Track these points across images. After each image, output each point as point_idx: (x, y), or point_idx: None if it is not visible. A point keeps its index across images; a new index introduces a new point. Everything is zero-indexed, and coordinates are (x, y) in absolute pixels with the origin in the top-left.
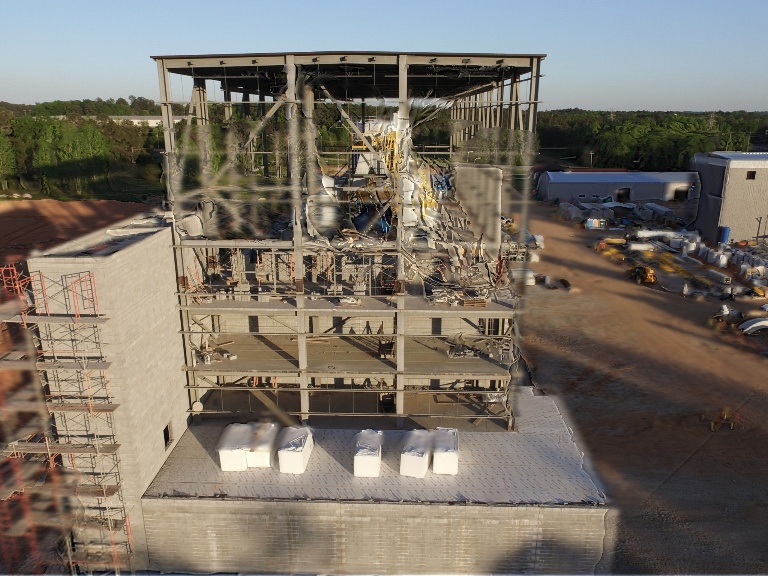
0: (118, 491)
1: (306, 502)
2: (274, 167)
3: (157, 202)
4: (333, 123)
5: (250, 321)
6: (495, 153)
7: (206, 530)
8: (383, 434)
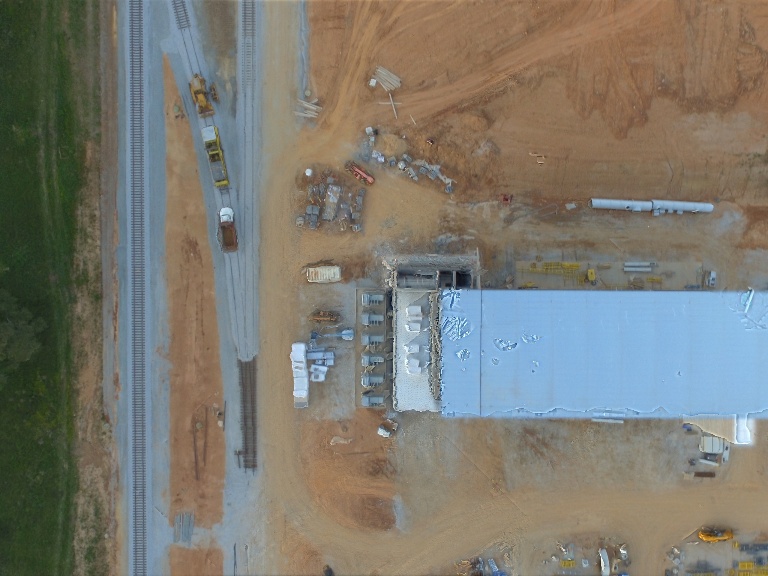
0: None
1: (395, 333)
2: None
3: None
4: None
5: None
6: None
7: None
8: (427, 352)
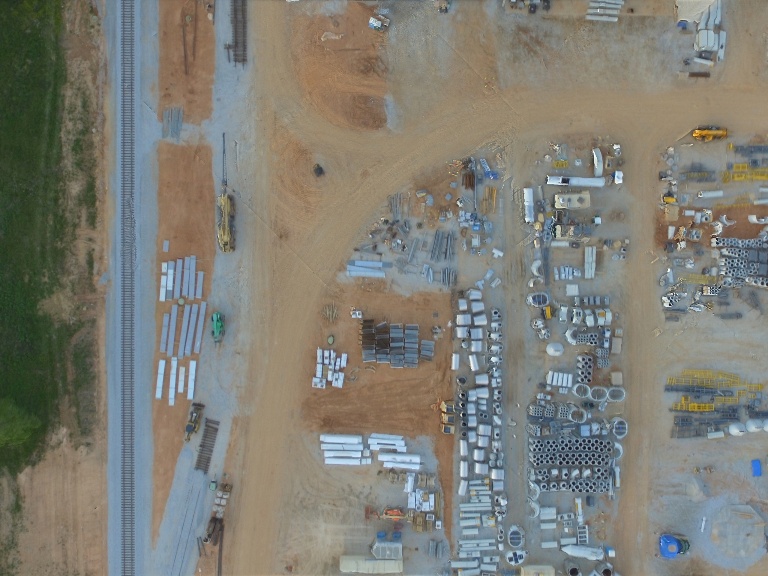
0: None
1: None
2: None
3: None
4: None
5: None
6: None
7: None
8: None
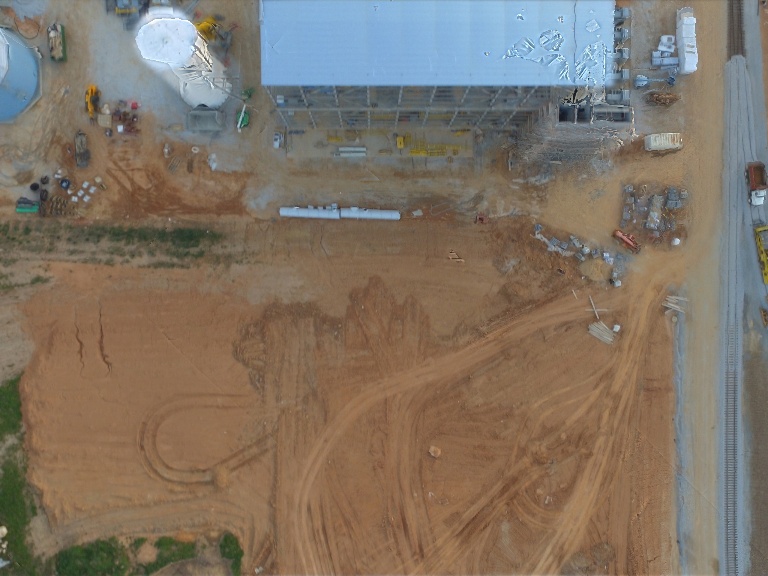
0: None
1: None
2: None
3: None
4: None
5: None
6: None
7: None
8: None
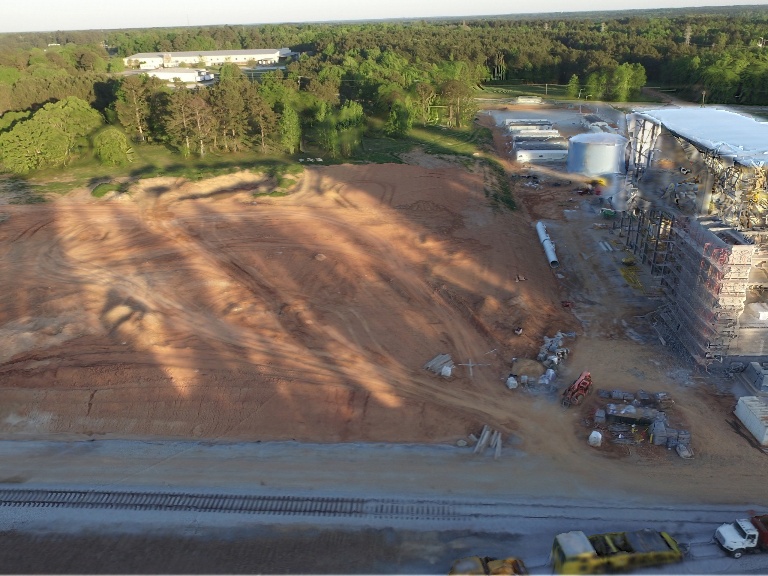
0: (734, 326)
1: None
2: (448, 119)
3: (413, 162)
4: (442, 60)
5: (759, 263)
6: (606, 90)
7: (761, 340)
8: None
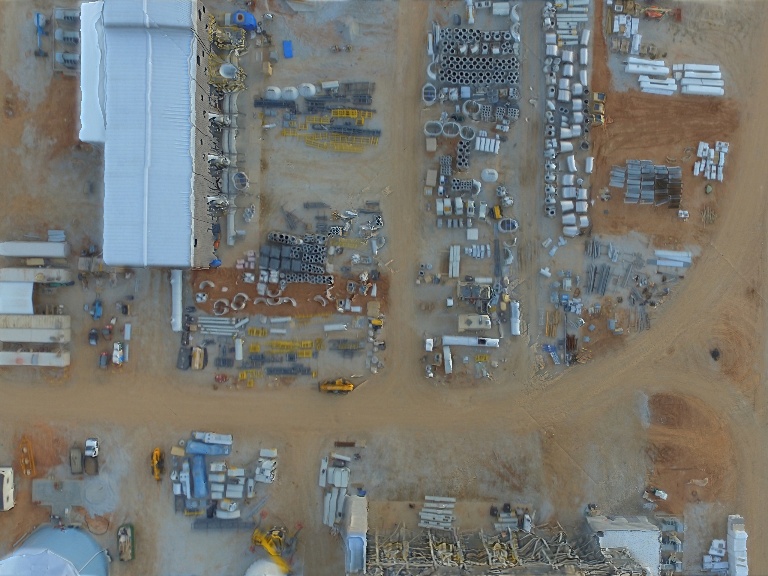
0: None
1: None
2: None
3: None
4: None
5: None
6: None
7: None
8: None
